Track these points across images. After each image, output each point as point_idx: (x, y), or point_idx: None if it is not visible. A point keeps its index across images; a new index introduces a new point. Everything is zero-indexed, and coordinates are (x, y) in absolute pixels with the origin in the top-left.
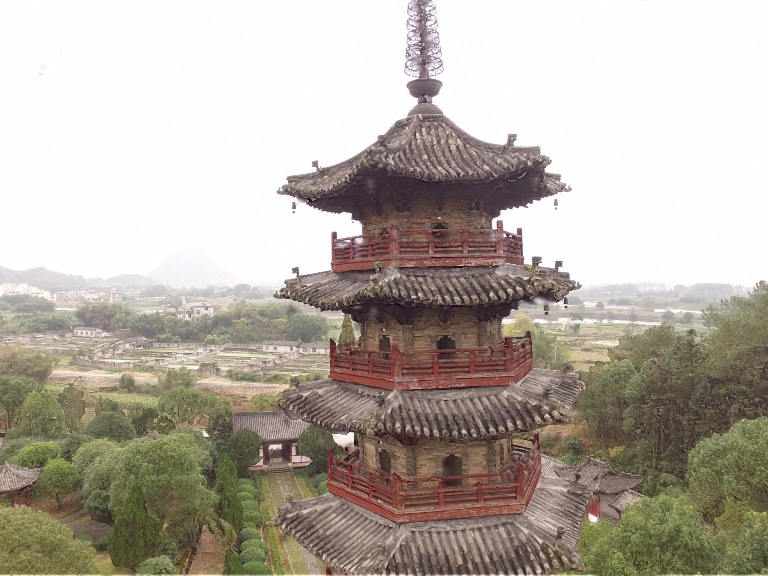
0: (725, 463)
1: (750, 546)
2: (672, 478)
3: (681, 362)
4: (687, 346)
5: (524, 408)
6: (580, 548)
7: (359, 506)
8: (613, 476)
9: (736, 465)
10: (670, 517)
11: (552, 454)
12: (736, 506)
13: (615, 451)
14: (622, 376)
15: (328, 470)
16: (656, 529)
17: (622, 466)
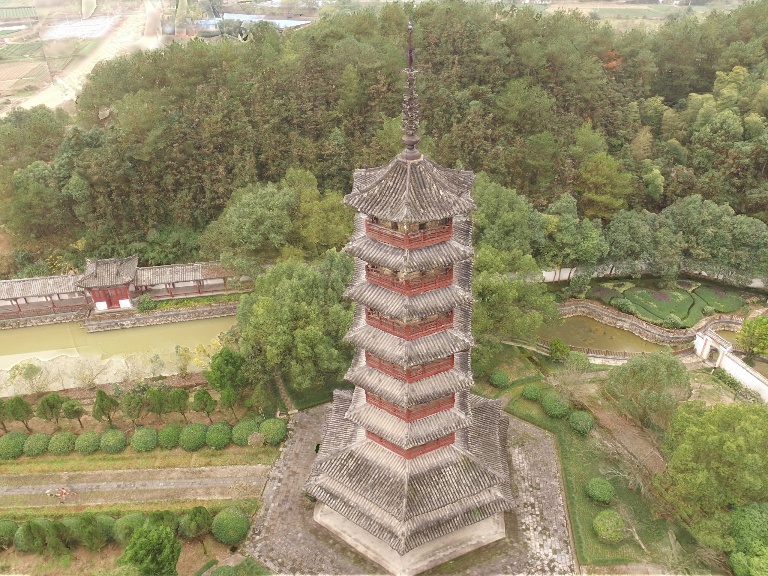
0: (266, 228)
1: (341, 265)
2: (143, 245)
3: (113, 155)
4: (112, 140)
5: (464, 265)
6: (269, 314)
7: (422, 336)
8: (122, 265)
9: (272, 226)
10: (308, 272)
11: (3, 274)
12: (288, 248)
13: (82, 245)
14: (48, 179)
15: (408, 333)
16: (304, 281)
17: (88, 253)
